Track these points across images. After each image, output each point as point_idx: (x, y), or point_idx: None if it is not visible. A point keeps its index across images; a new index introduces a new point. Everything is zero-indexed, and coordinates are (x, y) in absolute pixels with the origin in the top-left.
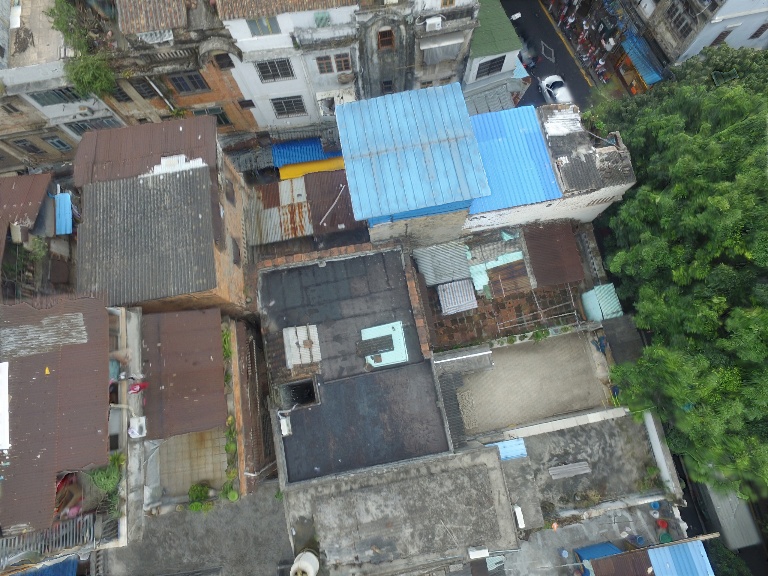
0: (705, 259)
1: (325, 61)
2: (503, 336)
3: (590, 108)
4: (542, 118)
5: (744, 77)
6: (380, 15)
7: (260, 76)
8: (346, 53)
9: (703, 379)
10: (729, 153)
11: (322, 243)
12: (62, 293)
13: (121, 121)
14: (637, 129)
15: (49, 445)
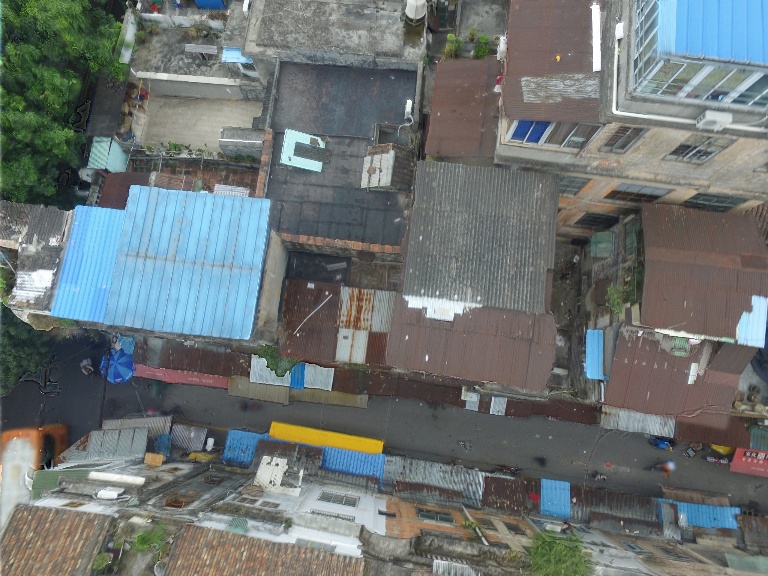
0: None
1: None
2: (208, 167)
3: (18, 437)
4: (49, 295)
5: None
6: None
7: None
8: None
9: (47, 5)
10: None
11: (337, 280)
12: None
13: (546, 538)
14: None
15: (559, 4)
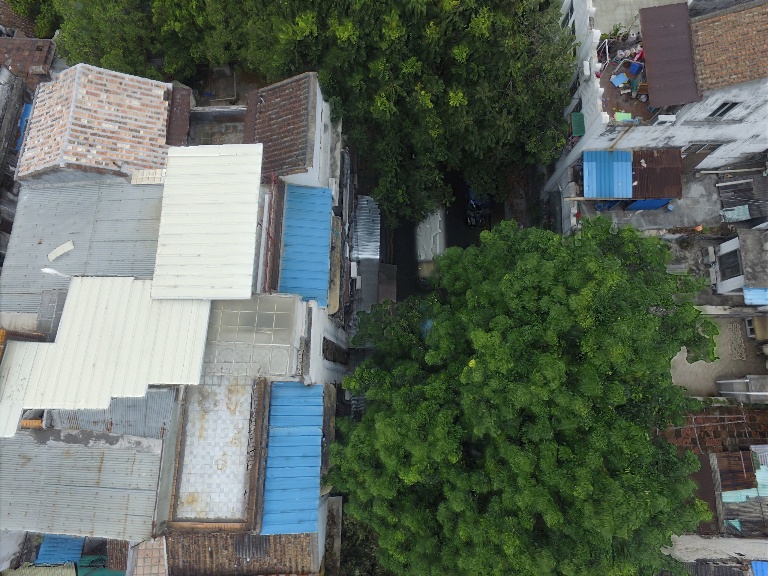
0: None
1: None
2: None
3: None
4: None
5: None
6: None
7: None
8: None
9: None
10: (627, 574)
11: None
12: None
13: None
14: None
15: None
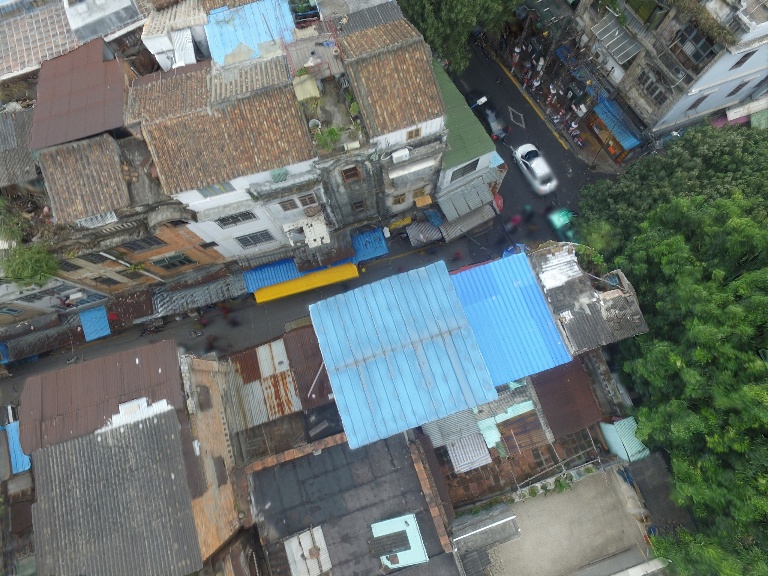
0: (741, 426)
1: (288, 202)
2: None
3: (569, 173)
4: (536, 268)
5: (737, 169)
6: (342, 159)
7: (219, 224)
8: (310, 194)
9: None
10: (752, 314)
11: (313, 415)
12: (29, 535)
13: (74, 284)
14: (637, 254)
15: None
